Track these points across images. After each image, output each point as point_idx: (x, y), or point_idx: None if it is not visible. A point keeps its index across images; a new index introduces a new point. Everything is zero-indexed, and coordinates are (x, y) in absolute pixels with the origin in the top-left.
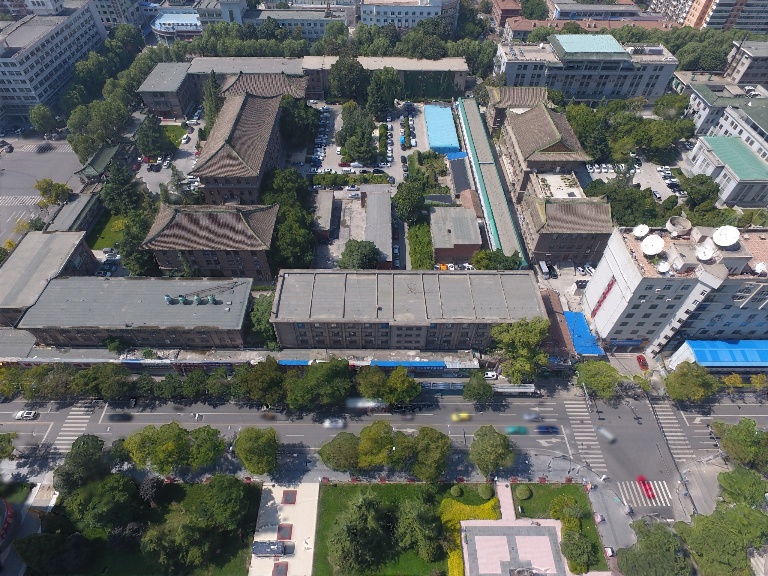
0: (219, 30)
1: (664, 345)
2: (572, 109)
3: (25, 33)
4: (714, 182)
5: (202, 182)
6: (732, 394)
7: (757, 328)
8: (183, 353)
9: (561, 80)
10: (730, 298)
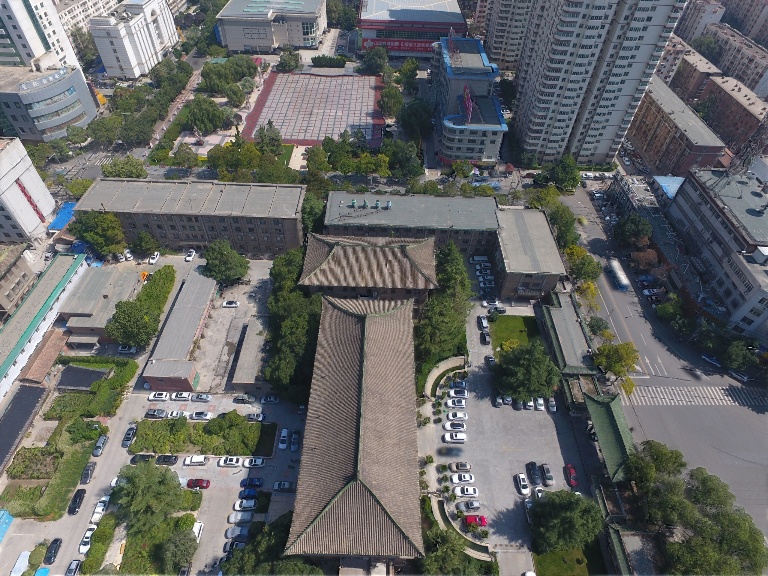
0: None
1: None
2: None
3: None
4: None
5: None
6: None
7: None
8: None
9: None
10: None
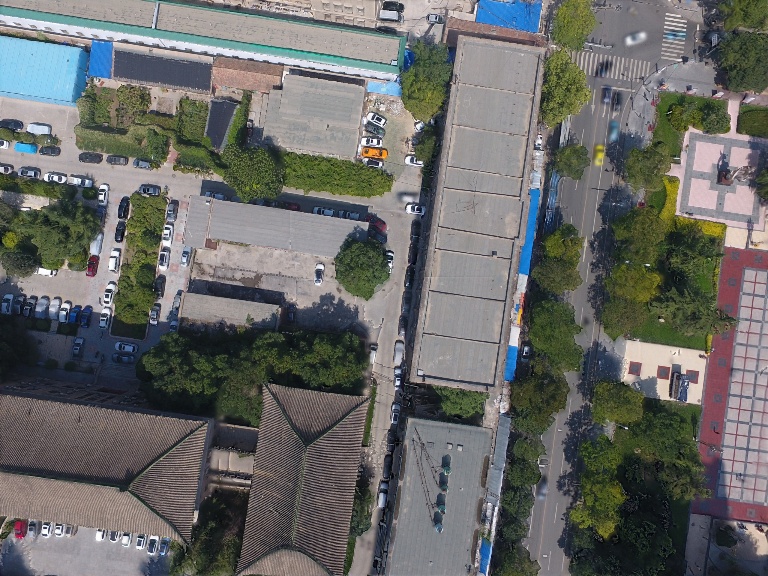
0: None
1: None
2: None
3: None
4: None
5: None
6: None
7: None
8: None
9: None
10: None
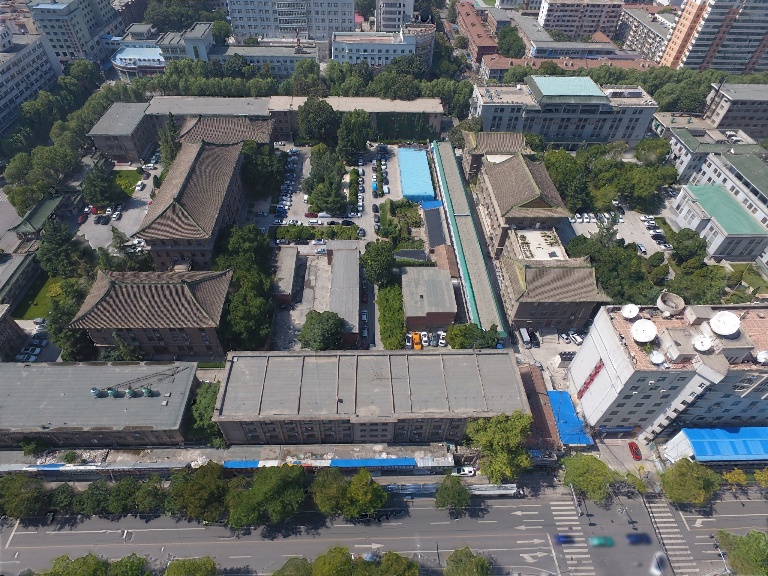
0: (182, 67)
1: (658, 433)
2: (551, 155)
3: None
4: (700, 235)
5: (148, 244)
6: (734, 489)
7: (758, 413)
8: (113, 454)
9: (539, 123)
10: (730, 388)
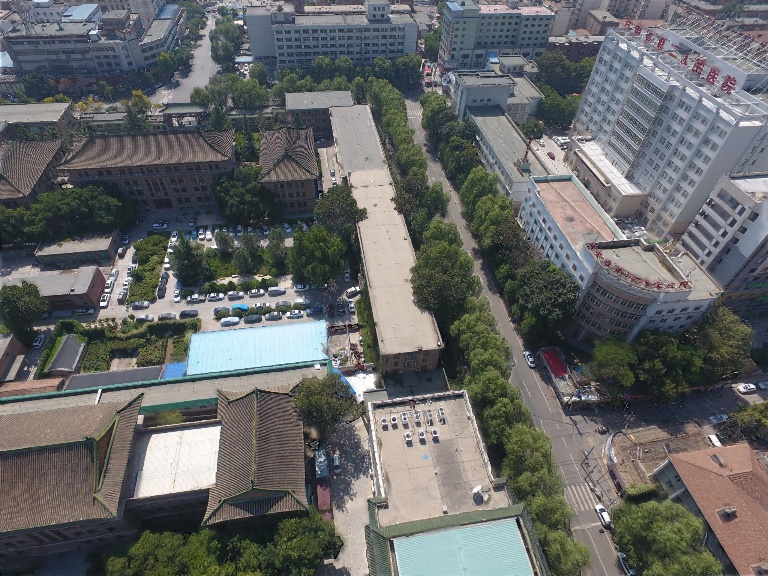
0: None
1: None
2: (211, 573)
3: (325, 19)
4: None
5: None
6: None
7: None
8: None
9: None
10: None
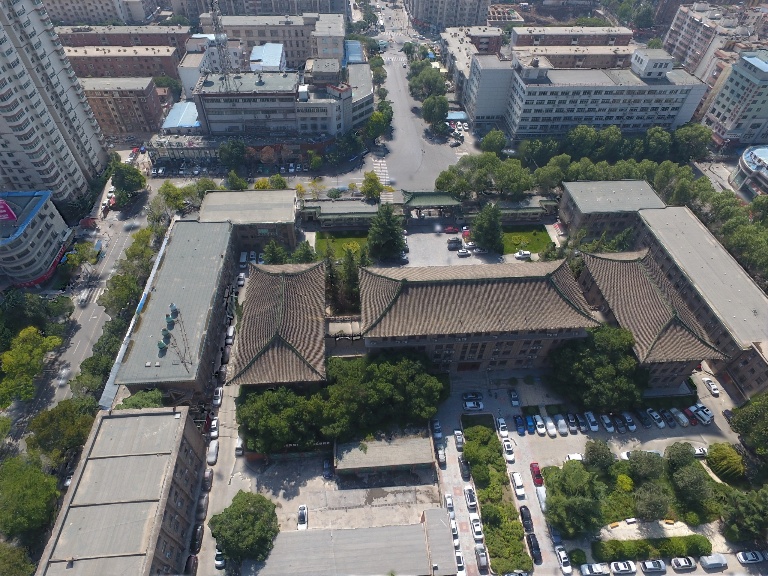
0: None
1: None
2: None
3: (584, 76)
4: None
5: None
6: None
7: None
8: None
9: None
10: None
